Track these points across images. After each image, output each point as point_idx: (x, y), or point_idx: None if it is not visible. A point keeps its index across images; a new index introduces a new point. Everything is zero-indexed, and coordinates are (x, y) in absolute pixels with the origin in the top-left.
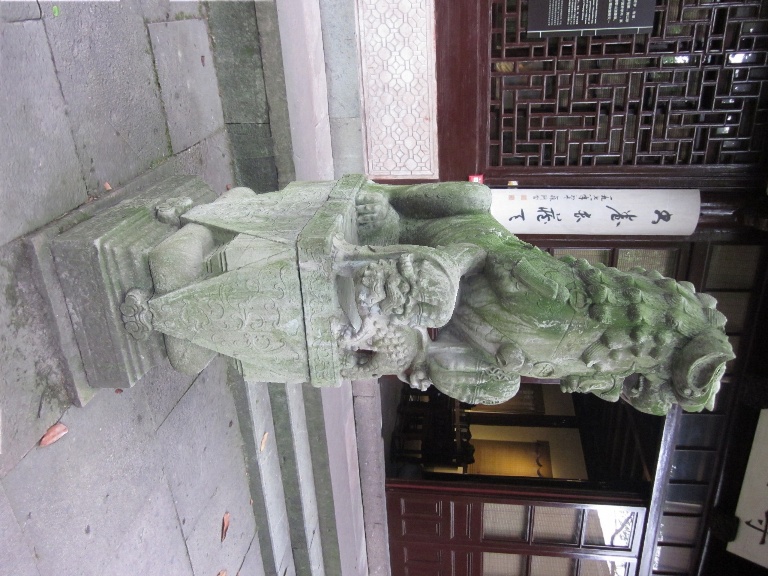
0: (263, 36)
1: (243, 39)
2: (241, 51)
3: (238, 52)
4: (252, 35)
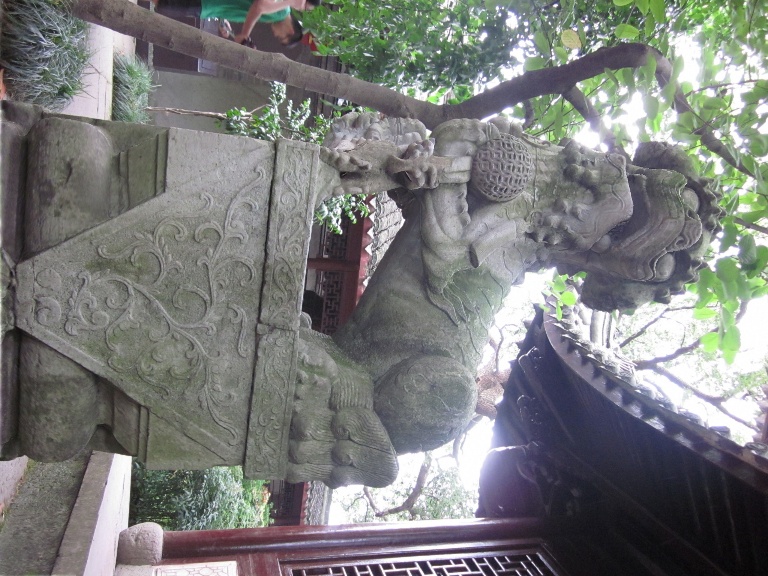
0: (63, 556)
1: (29, 565)
2: (20, 575)
3: (14, 575)
4: (45, 561)
